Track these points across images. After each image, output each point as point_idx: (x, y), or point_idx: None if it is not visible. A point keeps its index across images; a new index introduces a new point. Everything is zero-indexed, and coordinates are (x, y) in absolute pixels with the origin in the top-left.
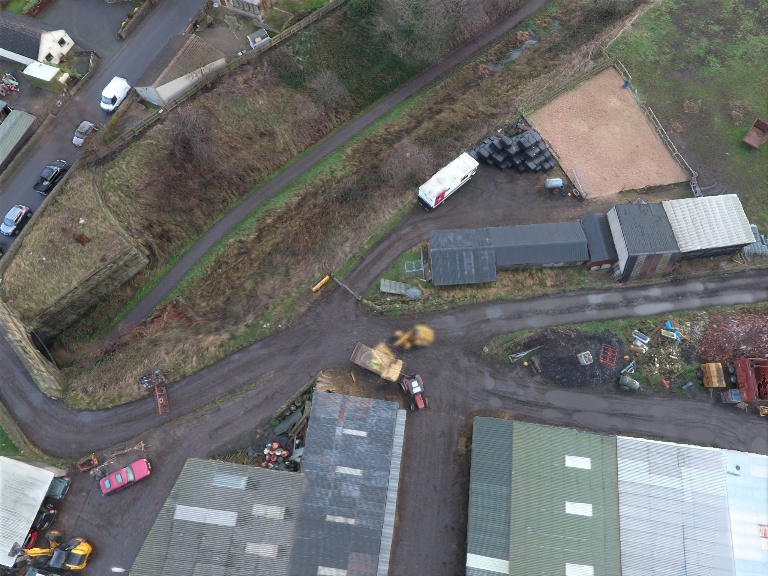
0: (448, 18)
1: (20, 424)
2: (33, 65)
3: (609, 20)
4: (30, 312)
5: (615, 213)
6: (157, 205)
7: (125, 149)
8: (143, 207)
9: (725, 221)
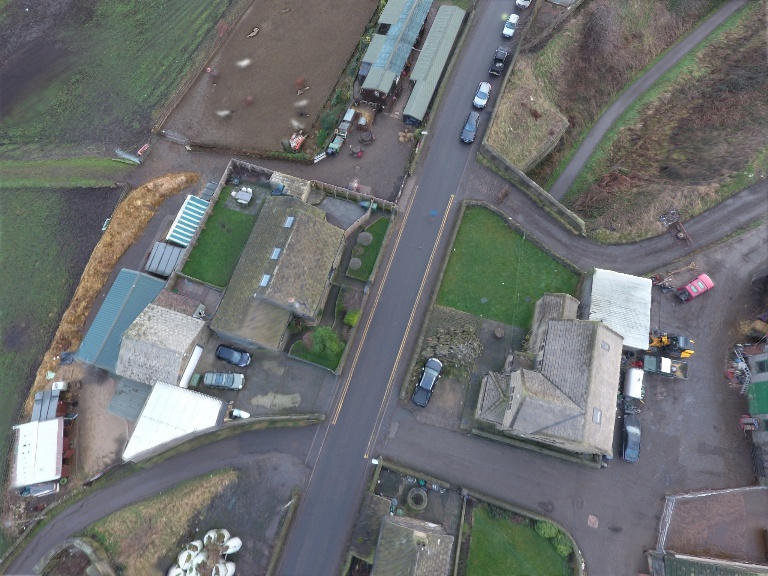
0: None
1: None
2: None
3: None
4: None
5: None
6: (567, 93)
7: (551, 39)
8: (557, 94)
9: None
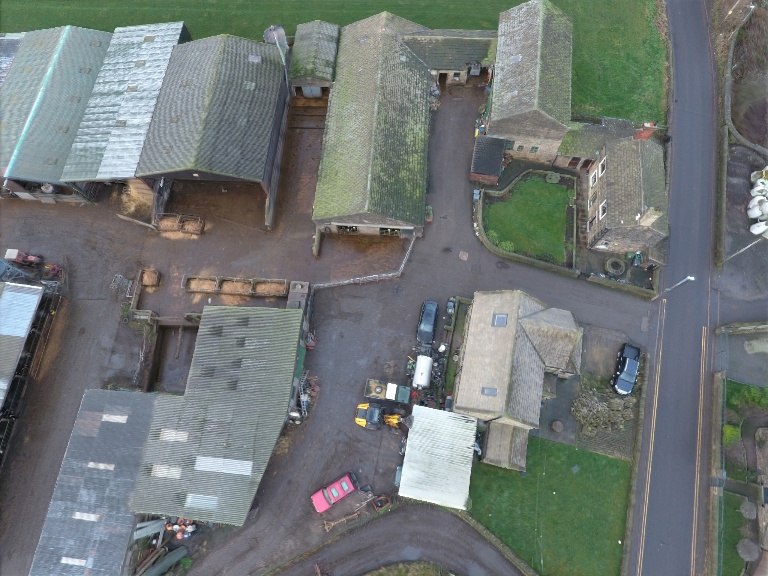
0: None
1: (484, 539)
2: None
3: None
4: None
5: None
6: None
7: None
8: None
9: None
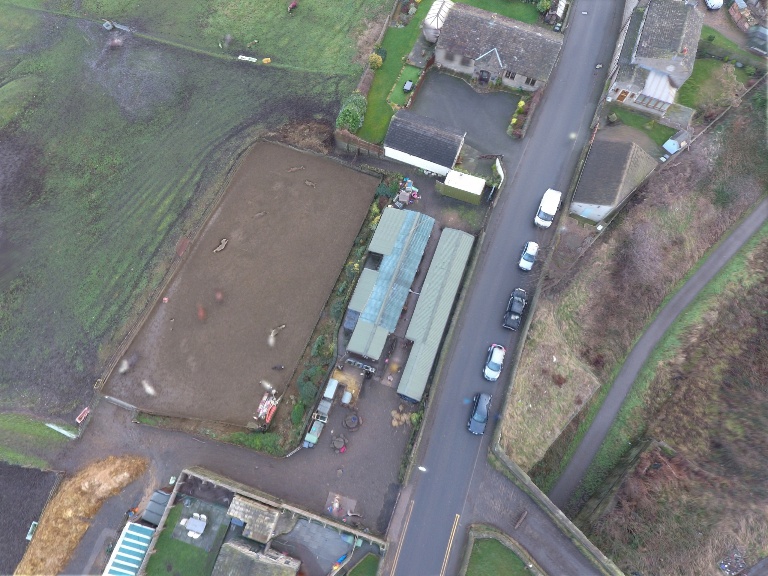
0: None
1: None
2: (452, 174)
3: None
4: (525, 468)
5: None
6: (596, 329)
7: (577, 273)
8: (584, 333)
9: None
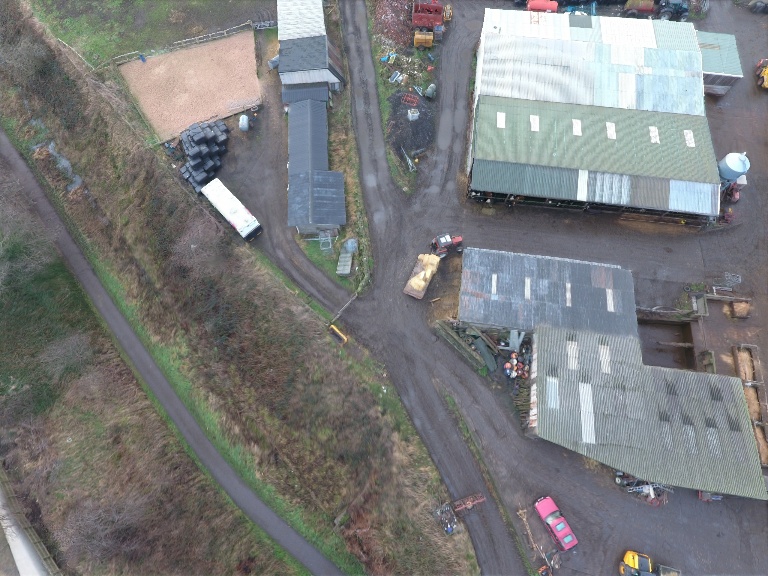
0: (4, 210)
1: None
2: None
3: (52, 69)
4: None
5: (286, 74)
6: None
7: None
8: None
9: (301, 4)
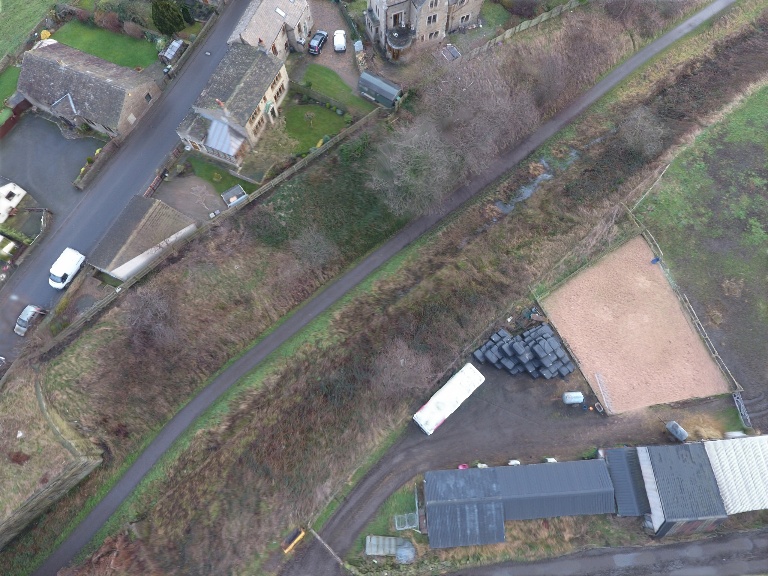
0: (452, 166)
1: None
2: None
3: (634, 162)
4: None
5: (648, 456)
6: (113, 397)
7: (75, 340)
8: (96, 401)
9: None
